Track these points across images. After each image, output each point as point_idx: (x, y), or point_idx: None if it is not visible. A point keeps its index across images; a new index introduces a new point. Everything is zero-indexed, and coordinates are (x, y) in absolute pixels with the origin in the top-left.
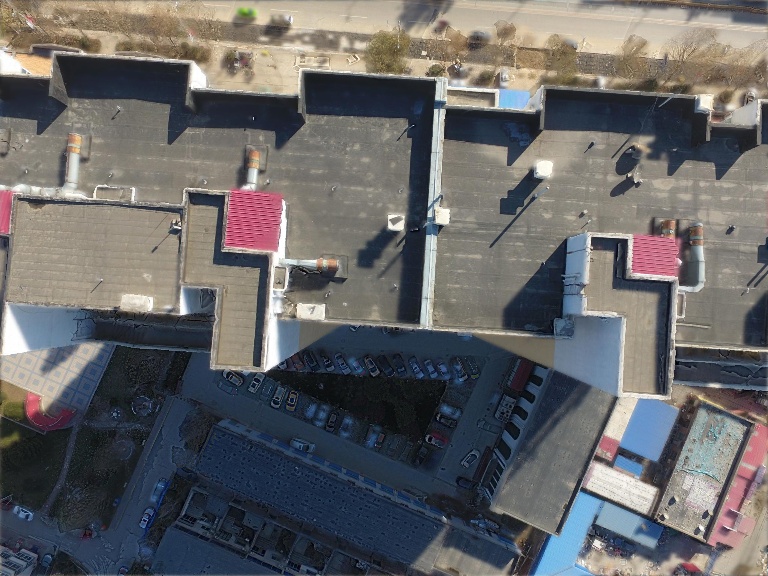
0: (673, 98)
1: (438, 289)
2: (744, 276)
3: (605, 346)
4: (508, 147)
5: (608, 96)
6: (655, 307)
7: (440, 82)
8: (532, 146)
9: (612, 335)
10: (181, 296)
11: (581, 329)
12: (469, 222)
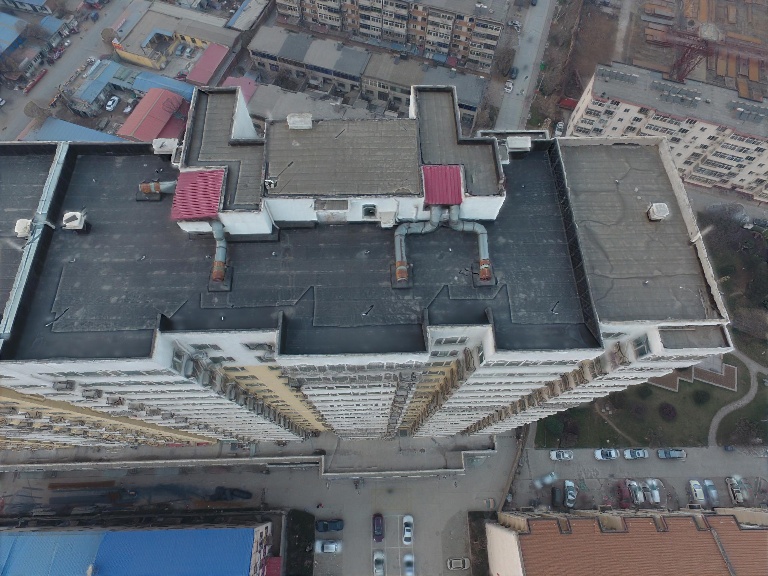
0: None
1: None
2: None
3: None
4: None
5: None
6: None
7: None
8: None
9: None
10: None
11: None
12: (8, 237)
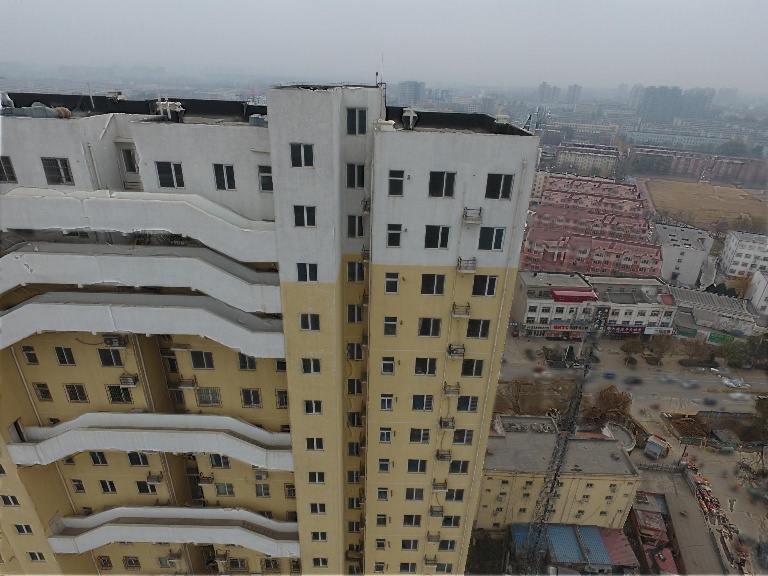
0: (96, 96)
1: None
2: None
3: None
4: None
5: (51, 99)
6: None
7: None
8: None
9: None
10: None
11: None
12: None
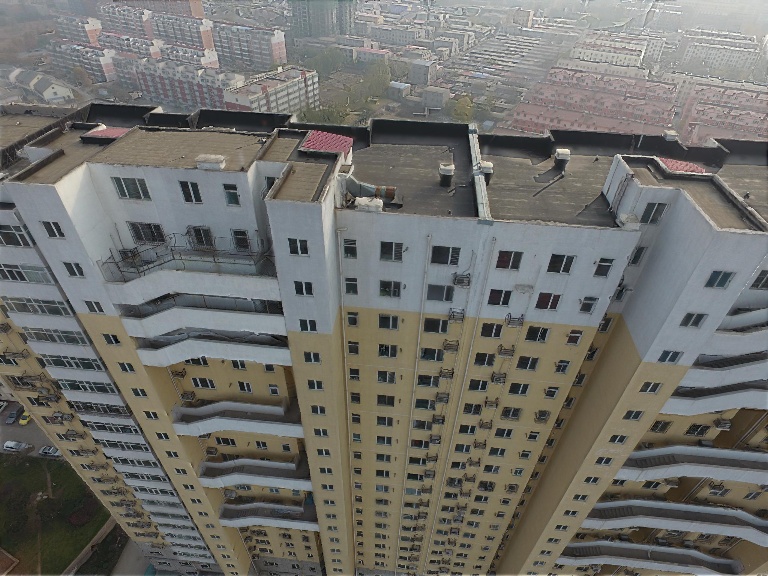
0: (645, 136)
1: (491, 215)
2: None
3: (679, 232)
4: (530, 159)
5: (597, 137)
6: (709, 194)
7: None
8: (549, 160)
9: (680, 214)
10: (252, 166)
11: (651, 273)
12: (510, 184)
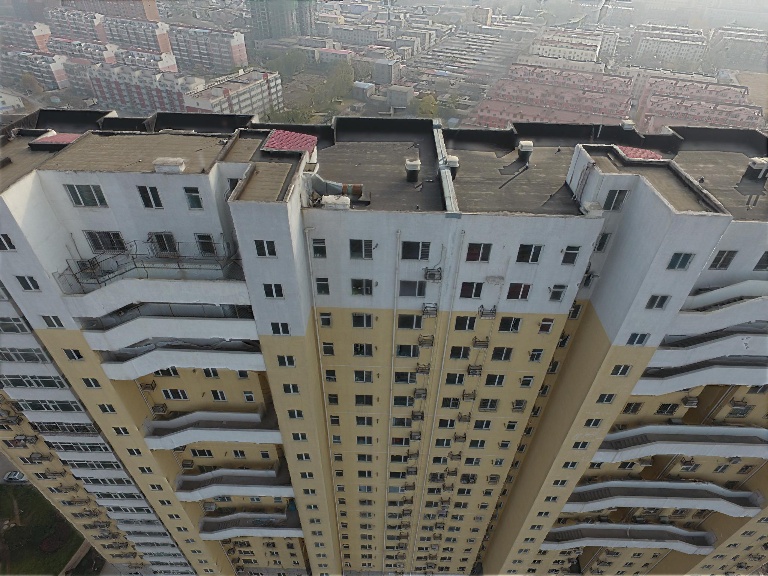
0: (604, 126)
1: (459, 209)
2: (738, 201)
3: (640, 217)
4: (495, 152)
5: (558, 129)
6: (666, 179)
7: (435, 120)
8: (513, 152)
9: (640, 200)
10: (213, 167)
11: (615, 258)
12: (476, 177)
